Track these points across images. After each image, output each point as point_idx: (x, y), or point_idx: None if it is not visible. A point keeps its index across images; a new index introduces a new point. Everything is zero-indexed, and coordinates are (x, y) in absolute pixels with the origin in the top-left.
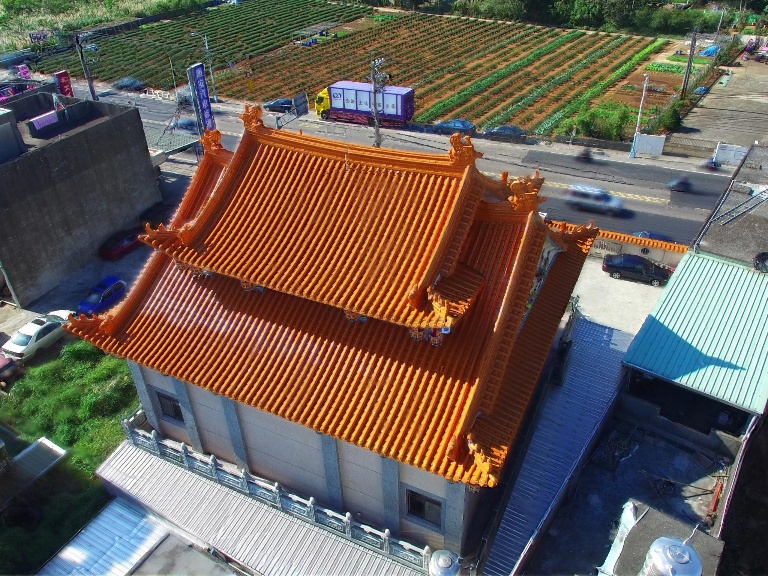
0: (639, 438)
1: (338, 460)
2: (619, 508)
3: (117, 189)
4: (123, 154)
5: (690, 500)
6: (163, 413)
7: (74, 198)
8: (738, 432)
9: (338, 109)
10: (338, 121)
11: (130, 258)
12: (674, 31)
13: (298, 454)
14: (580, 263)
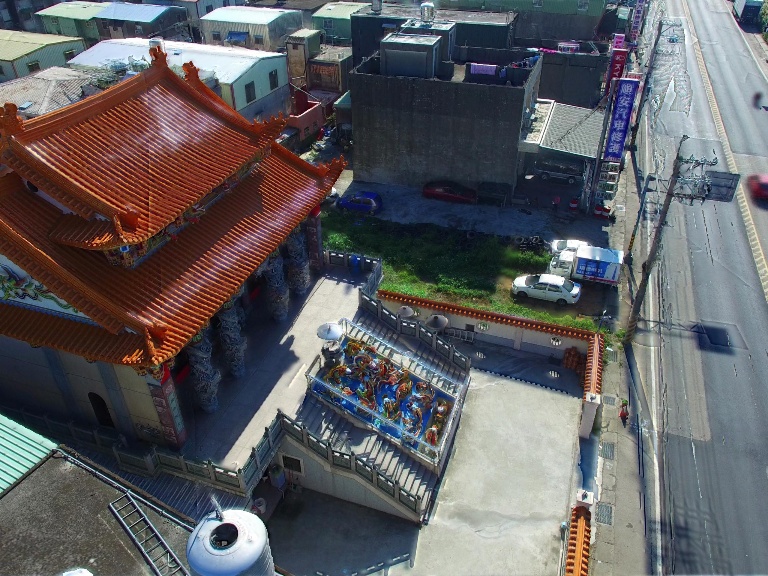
0: None
1: None
2: None
3: (470, 147)
4: (489, 122)
5: None
6: None
7: (426, 131)
8: None
9: None
10: None
11: (431, 202)
12: None
13: None
14: (103, 354)
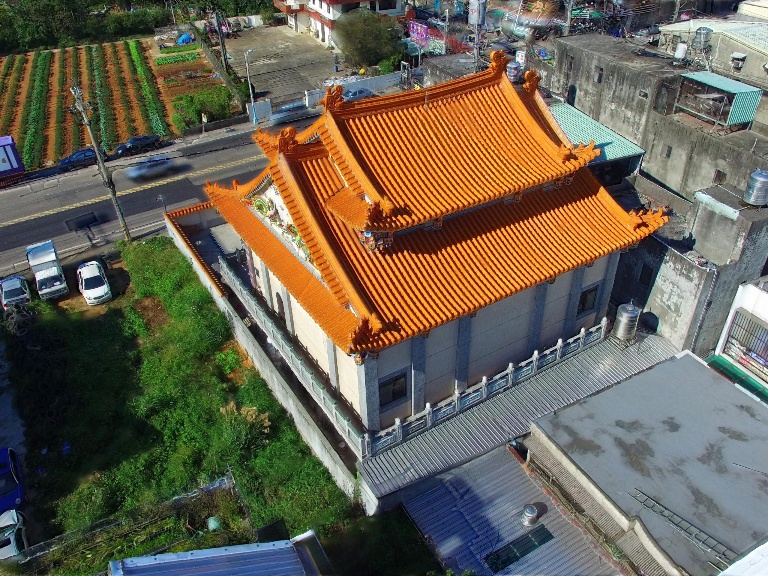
0: None
1: None
2: None
3: None
4: None
5: None
6: (381, 406)
7: None
8: None
9: None
10: None
11: None
12: (132, 32)
13: (510, 332)
14: None
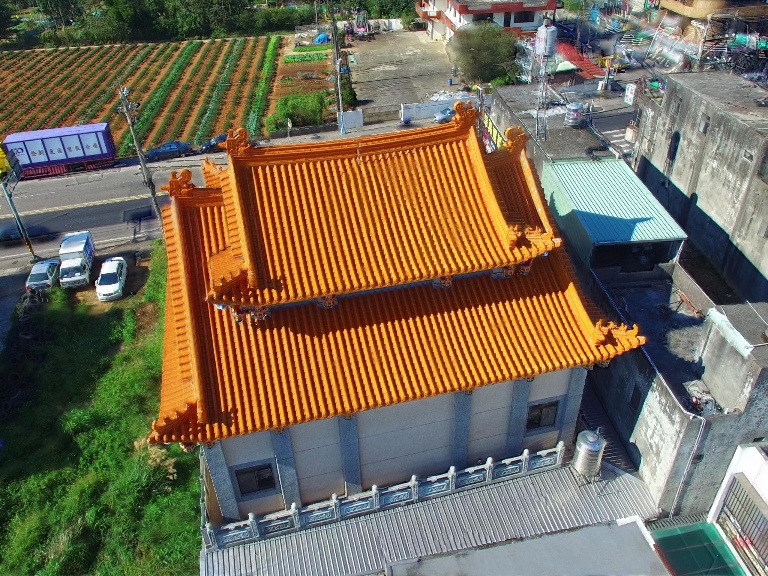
0: (619, 293)
1: (469, 417)
2: (658, 336)
3: None
4: None
5: (680, 311)
6: (241, 494)
7: None
8: (662, 261)
9: (23, 166)
10: (27, 180)
11: None
12: (278, 28)
13: (422, 438)
14: None
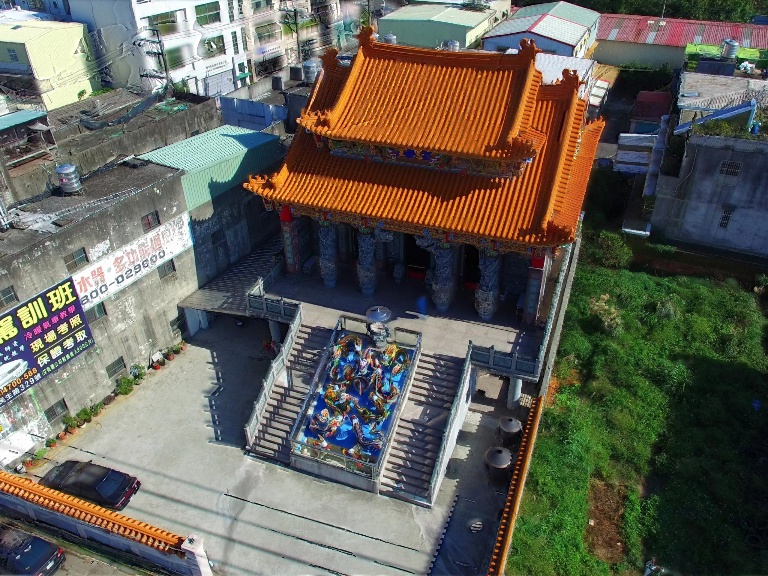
0: None
1: None
2: None
3: None
4: None
5: None
6: None
7: None
8: None
9: None
10: None
11: None
12: None
13: None
14: (272, 175)
